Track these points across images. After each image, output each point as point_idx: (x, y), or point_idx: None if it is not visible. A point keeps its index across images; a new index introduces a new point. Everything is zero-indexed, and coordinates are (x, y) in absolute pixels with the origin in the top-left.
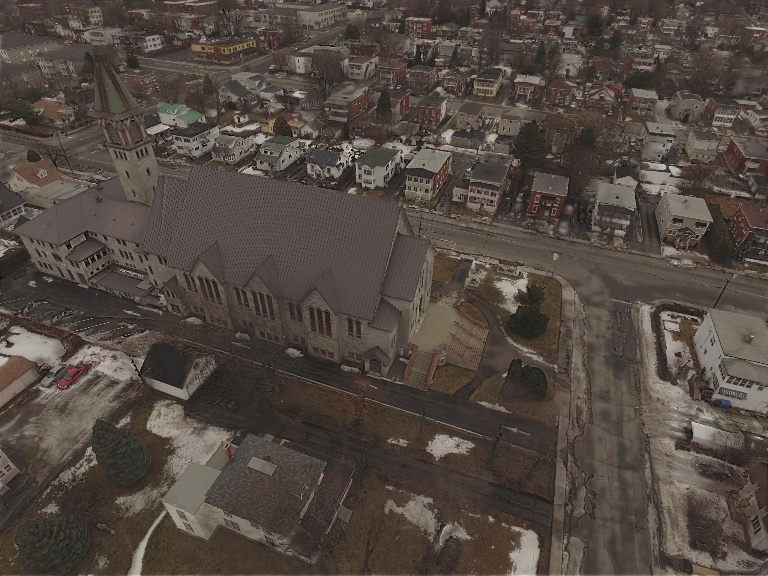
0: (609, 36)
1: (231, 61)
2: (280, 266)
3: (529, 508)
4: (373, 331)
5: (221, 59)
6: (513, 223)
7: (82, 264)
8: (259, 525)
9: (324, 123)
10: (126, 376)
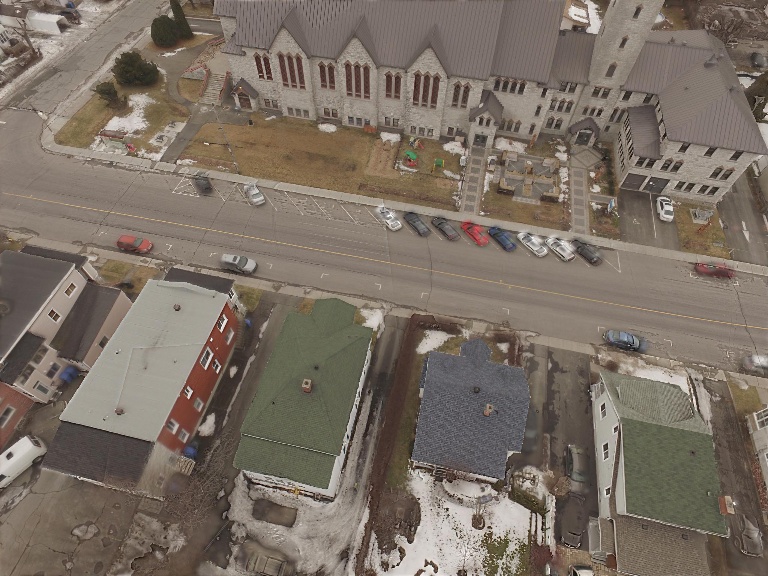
0: None
1: None
2: None
3: (201, 1)
4: None
5: None
6: None
7: None
8: None
9: None
10: None
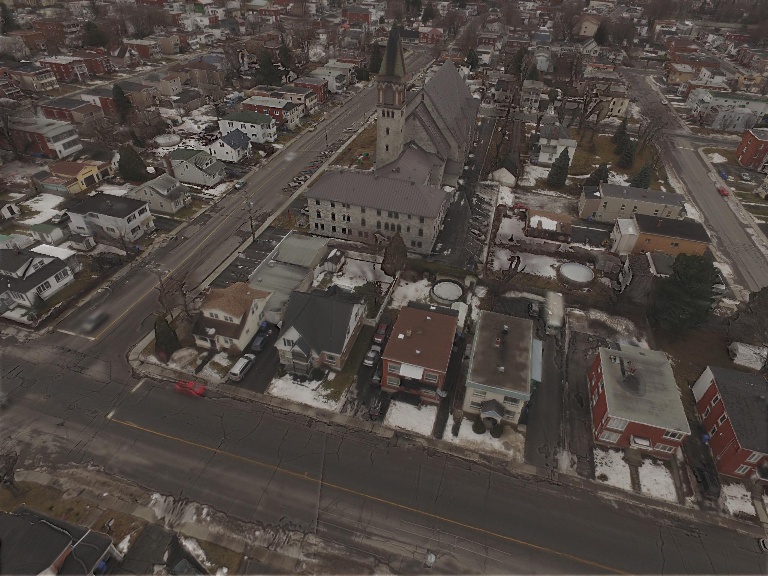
0: None
1: None
2: None
3: None
4: None
5: None
6: (331, 108)
7: None
8: None
9: (87, 155)
10: (511, 194)
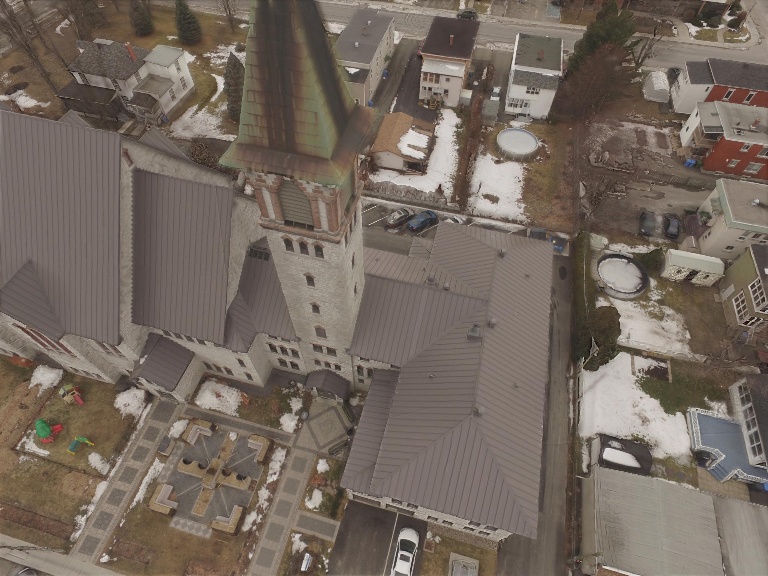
0: None
1: None
2: None
3: None
4: None
5: None
6: None
7: None
8: None
9: None
10: None
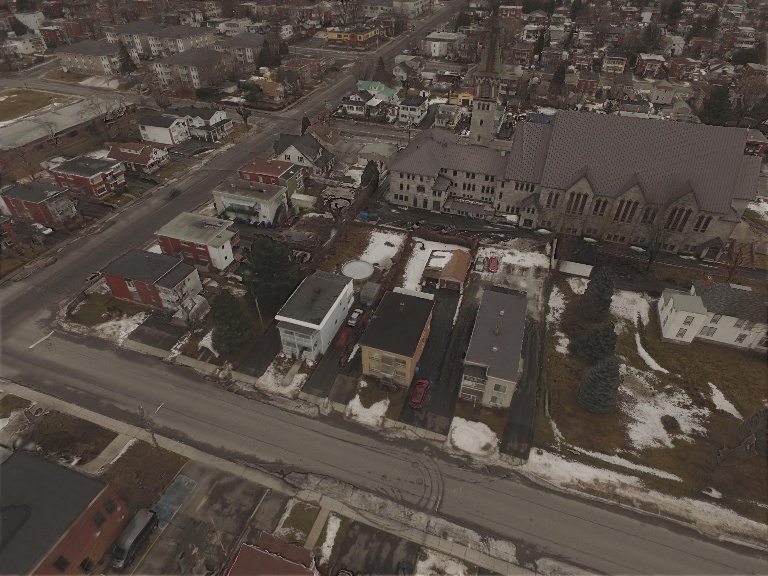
0: (707, 19)
1: (365, 47)
2: (645, 180)
3: None
4: (720, 224)
5: (356, 45)
6: None
7: (444, 193)
8: (744, 324)
9: None
10: (530, 264)
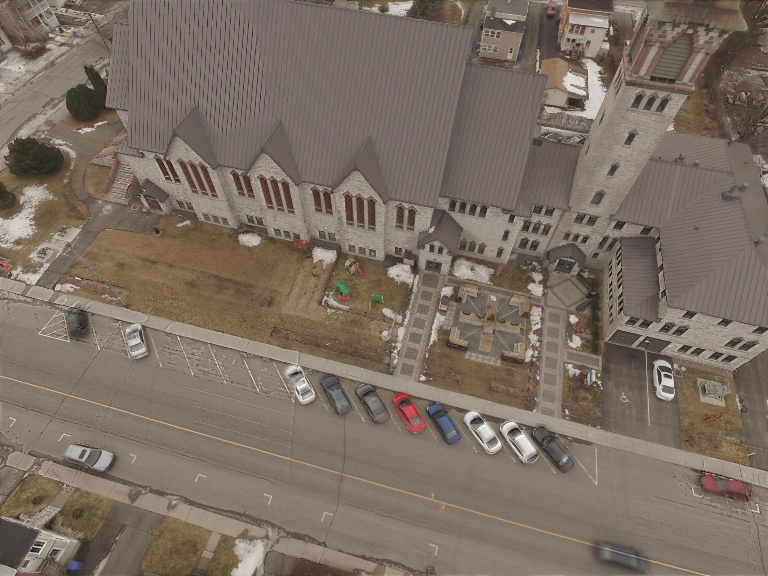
0: None
1: None
2: None
3: None
4: None
5: None
6: None
7: None
8: None
9: None
10: None
